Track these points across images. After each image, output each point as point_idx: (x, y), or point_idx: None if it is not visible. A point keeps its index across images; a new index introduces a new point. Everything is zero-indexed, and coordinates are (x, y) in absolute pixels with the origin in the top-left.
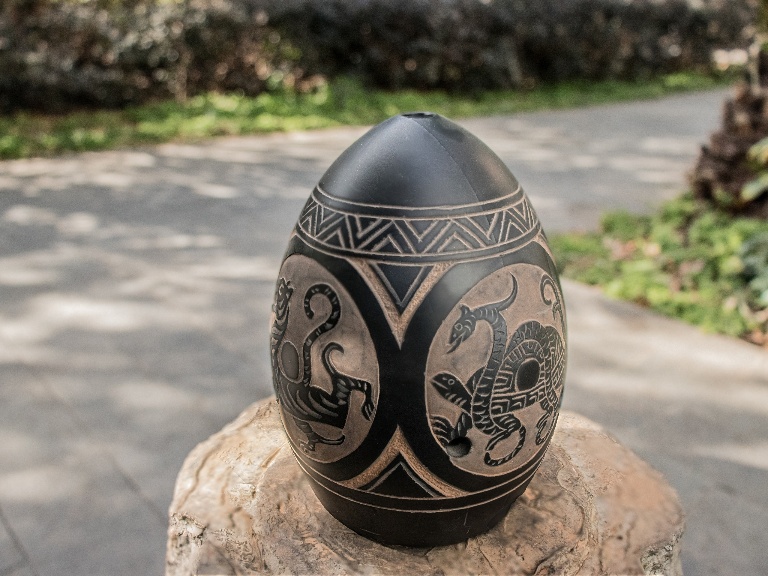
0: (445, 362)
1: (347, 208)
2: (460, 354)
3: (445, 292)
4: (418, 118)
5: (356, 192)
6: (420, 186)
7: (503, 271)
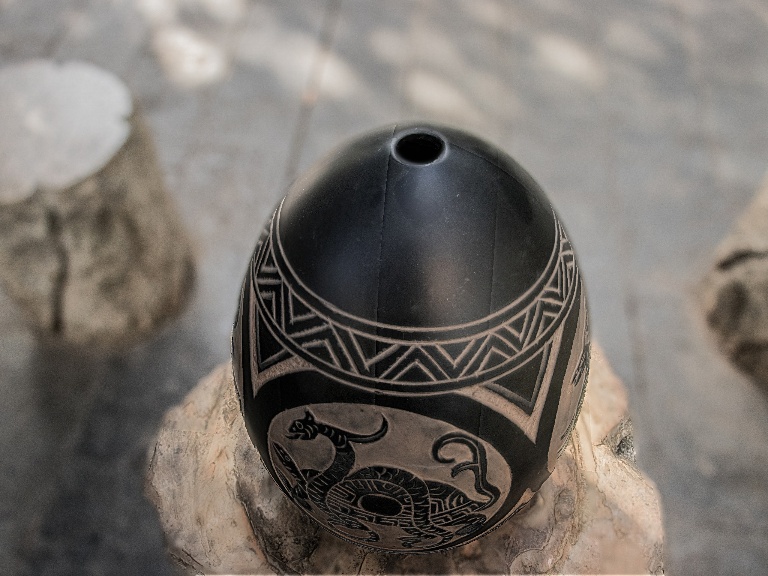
0: (283, 441)
1: (273, 227)
2: (297, 446)
3: (295, 387)
4: (415, 153)
5: (285, 217)
6: (320, 263)
7: (372, 408)
